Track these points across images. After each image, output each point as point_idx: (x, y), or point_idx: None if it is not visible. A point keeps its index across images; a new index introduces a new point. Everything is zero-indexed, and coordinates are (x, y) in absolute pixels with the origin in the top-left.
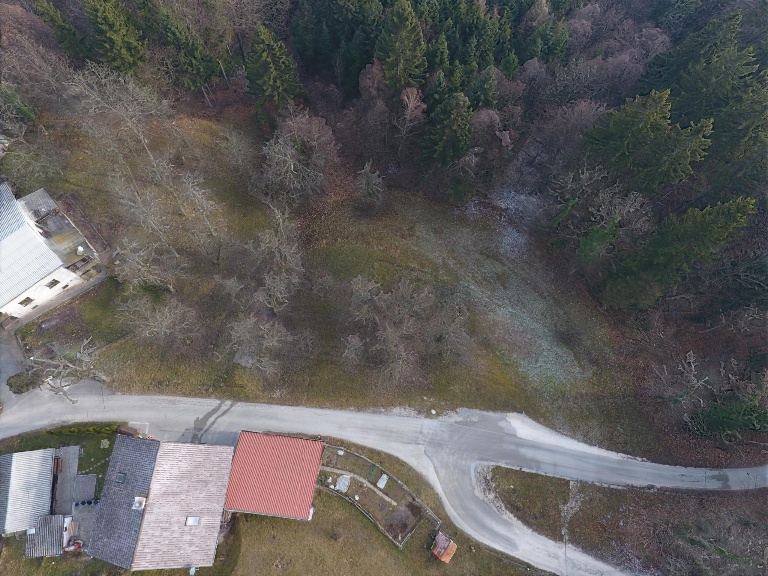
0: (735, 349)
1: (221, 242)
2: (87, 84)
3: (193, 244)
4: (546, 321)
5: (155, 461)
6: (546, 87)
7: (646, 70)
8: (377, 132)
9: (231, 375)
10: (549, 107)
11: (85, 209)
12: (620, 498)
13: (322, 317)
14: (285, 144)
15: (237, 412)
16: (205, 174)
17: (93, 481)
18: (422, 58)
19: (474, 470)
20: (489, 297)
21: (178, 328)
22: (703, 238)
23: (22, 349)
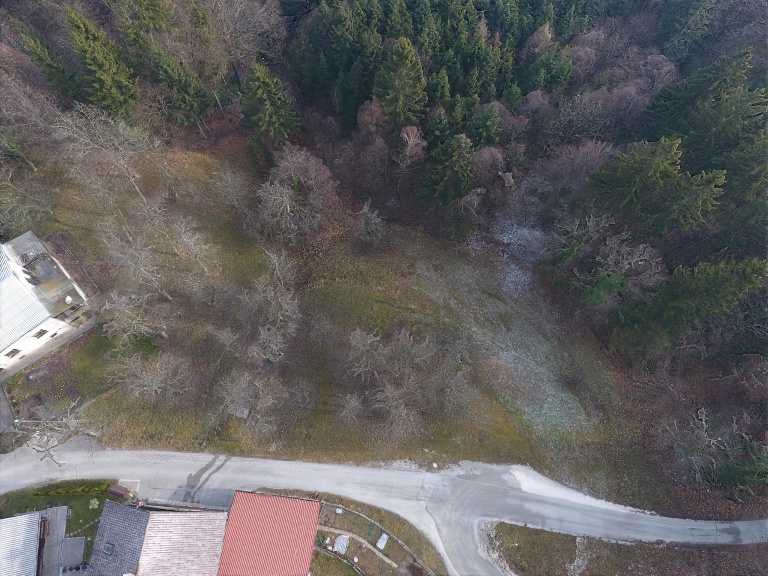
0: (745, 391)
1: (215, 289)
2: (76, 126)
3: (187, 285)
4: (550, 364)
5: (144, 534)
6: (550, 120)
7: (652, 102)
8: (376, 168)
9: (225, 427)
10: (553, 142)
11: (75, 250)
12: (628, 555)
13: (320, 363)
14: (281, 186)
15: (231, 468)
16: (199, 211)
17: (81, 544)
18: (422, 93)
19: (477, 527)
20: (492, 340)
21: (170, 382)
22: (716, 294)
23: (8, 402)
